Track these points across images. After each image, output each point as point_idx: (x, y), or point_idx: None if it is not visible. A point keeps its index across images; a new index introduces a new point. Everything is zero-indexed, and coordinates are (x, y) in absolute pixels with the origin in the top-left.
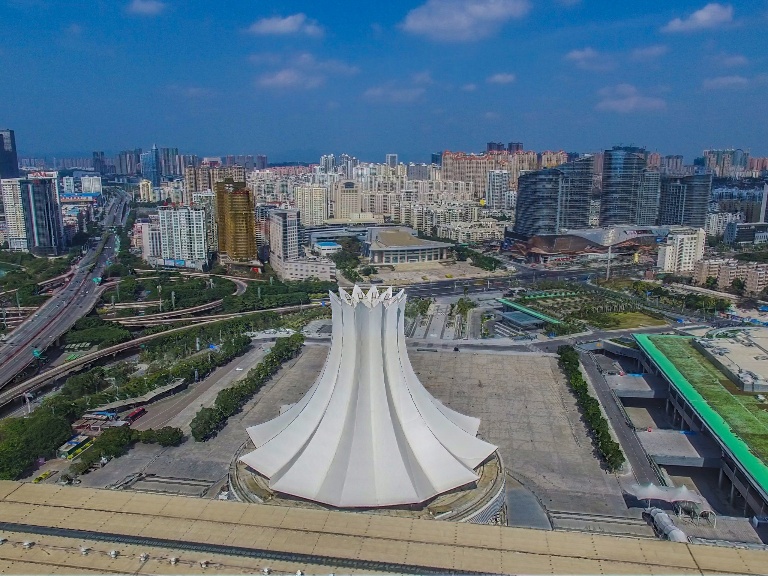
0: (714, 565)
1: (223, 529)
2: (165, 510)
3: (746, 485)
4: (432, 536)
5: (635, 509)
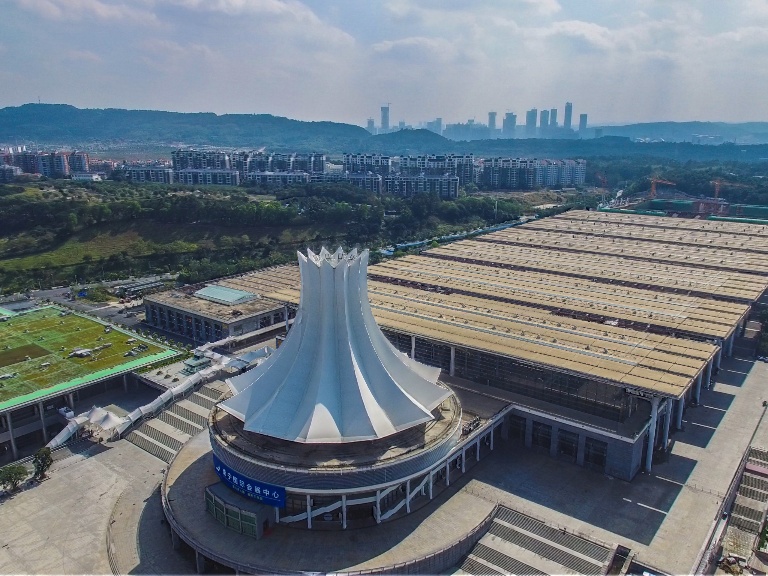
0: (292, 297)
1: (482, 337)
2: (514, 349)
3: (2, 431)
4: (383, 319)
5: (111, 445)
